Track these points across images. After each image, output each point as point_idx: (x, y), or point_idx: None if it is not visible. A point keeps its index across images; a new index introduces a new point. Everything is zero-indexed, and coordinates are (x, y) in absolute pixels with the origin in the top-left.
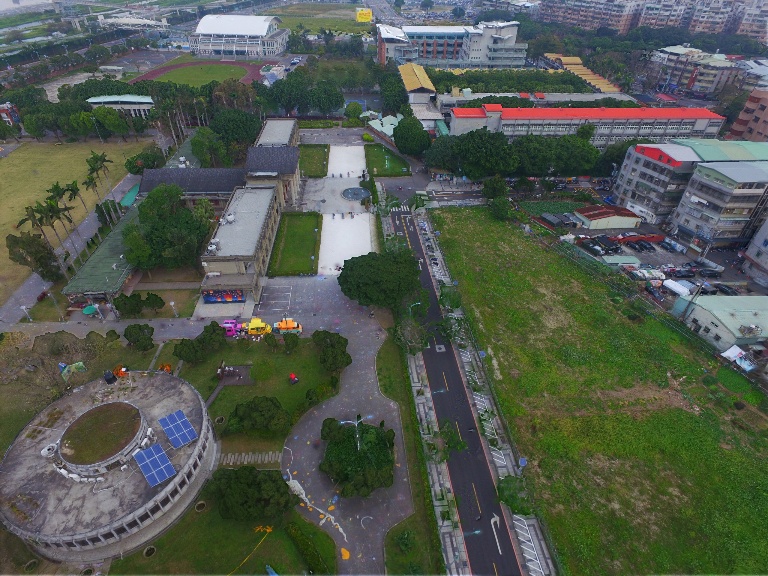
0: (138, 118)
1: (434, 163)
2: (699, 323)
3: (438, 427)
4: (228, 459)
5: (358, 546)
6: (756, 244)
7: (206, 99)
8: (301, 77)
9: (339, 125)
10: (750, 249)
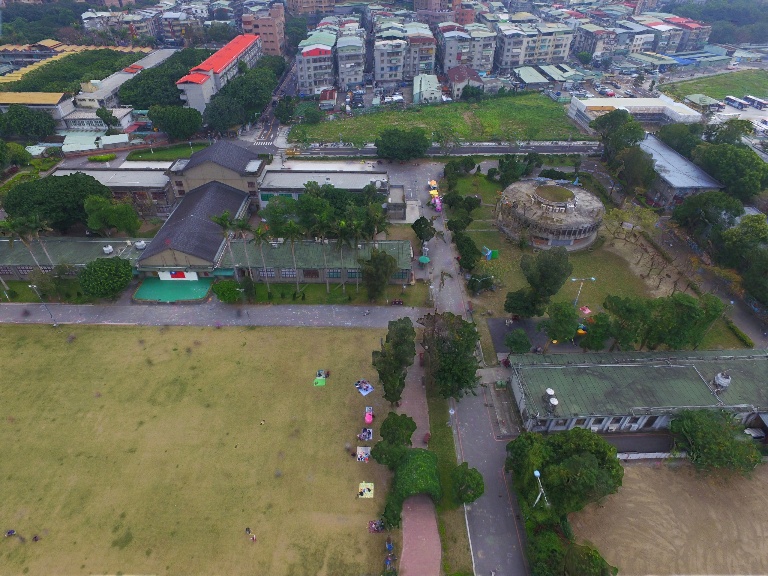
0: None
1: (234, 122)
2: (427, 98)
3: (495, 153)
4: None
5: None
6: (378, 72)
7: None
8: None
9: None
10: (377, 76)
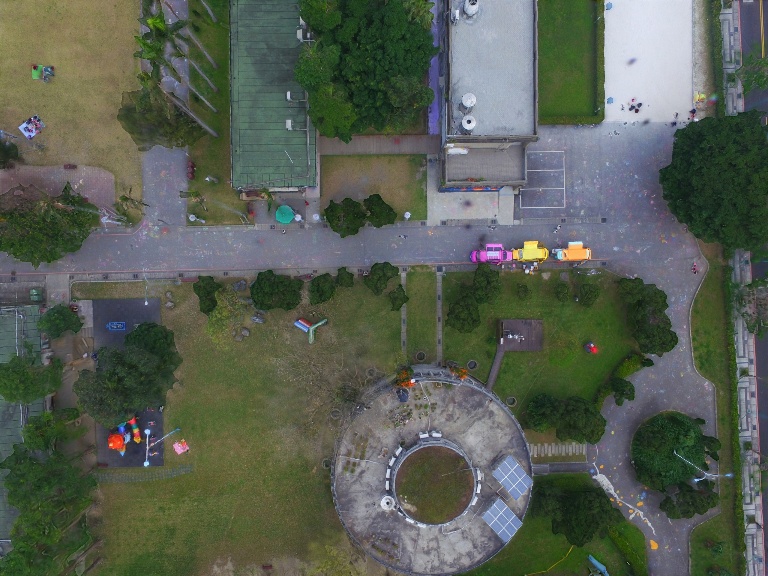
0: None
1: None
2: None
3: (758, 421)
4: (531, 451)
5: (666, 539)
6: None
7: None
8: None
9: None
10: None
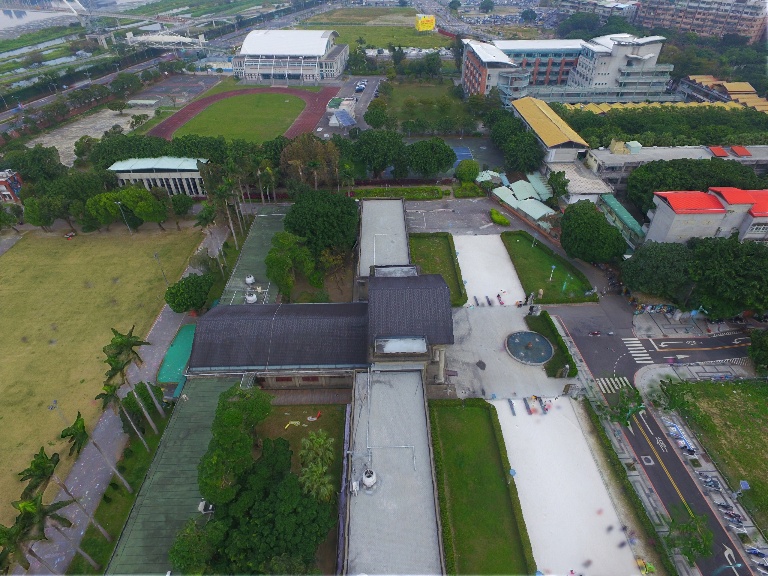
0: (180, 196)
1: (647, 290)
2: None
3: None
4: None
5: None
6: None
7: (274, 169)
8: (383, 117)
9: (450, 194)
10: None
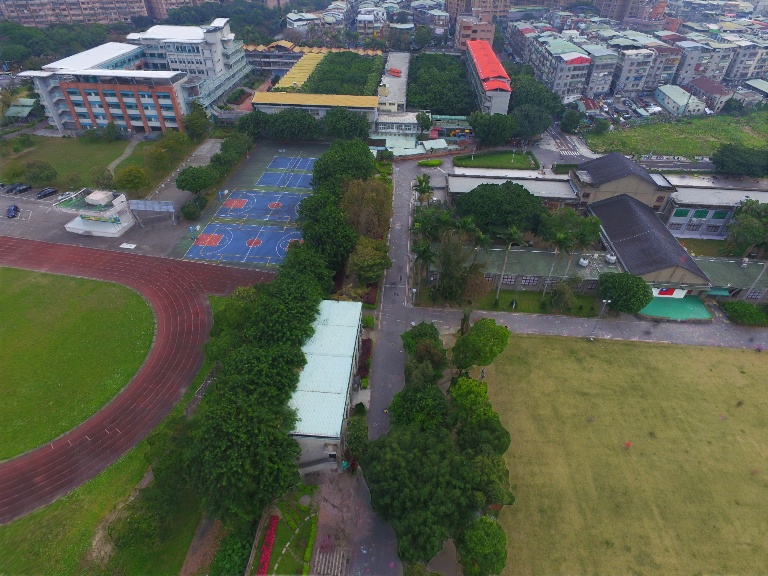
0: (429, 326)
1: None
2: (691, 110)
3: None
4: None
5: None
6: None
7: None
8: None
9: None
10: None
